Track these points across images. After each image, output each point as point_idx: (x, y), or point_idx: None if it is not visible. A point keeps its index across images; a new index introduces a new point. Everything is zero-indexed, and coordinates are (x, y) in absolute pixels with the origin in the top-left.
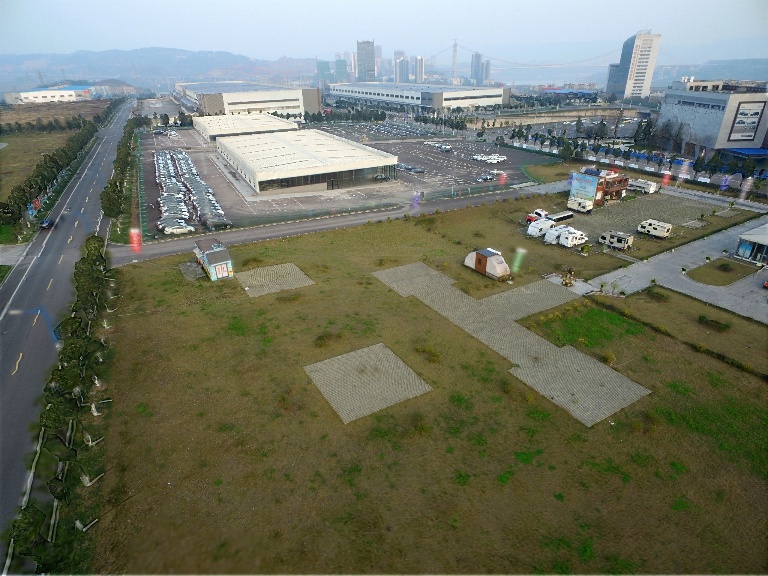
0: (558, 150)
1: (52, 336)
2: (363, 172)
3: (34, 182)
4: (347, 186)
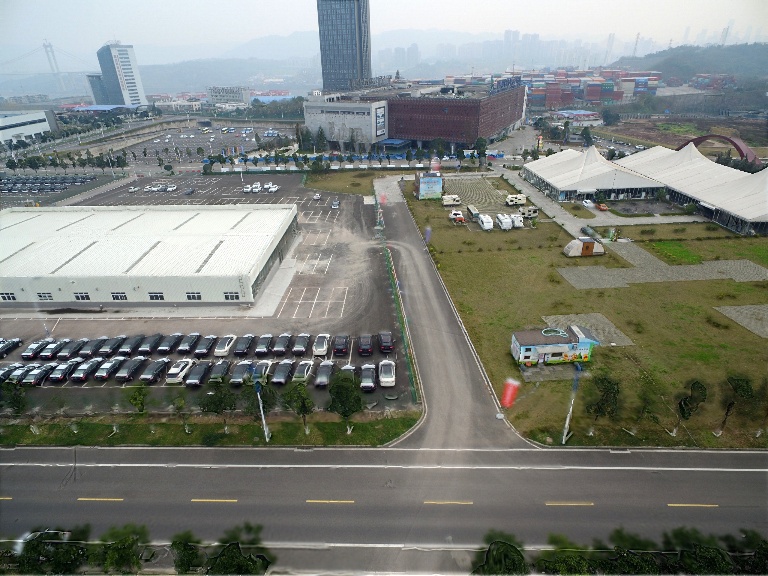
0: (308, 166)
1: (745, 482)
2: (288, 232)
3: None
4: (285, 253)
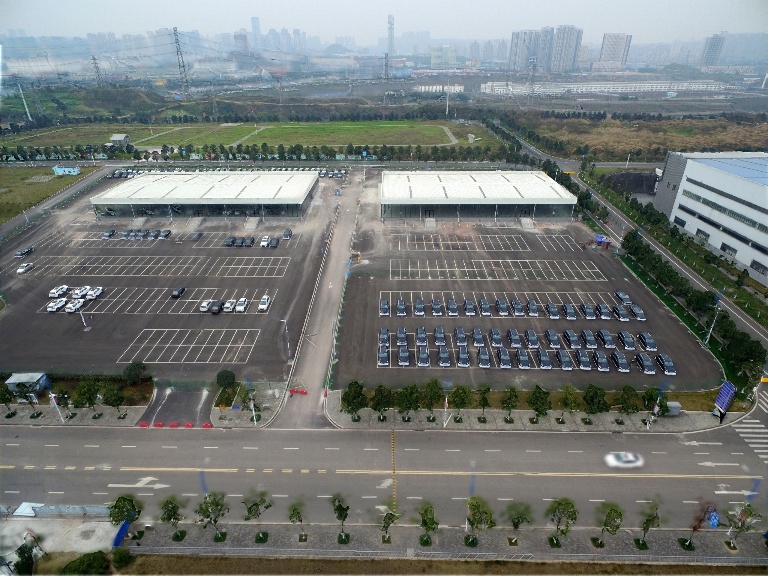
0: None
1: None
2: None
3: (204, 147)
4: None
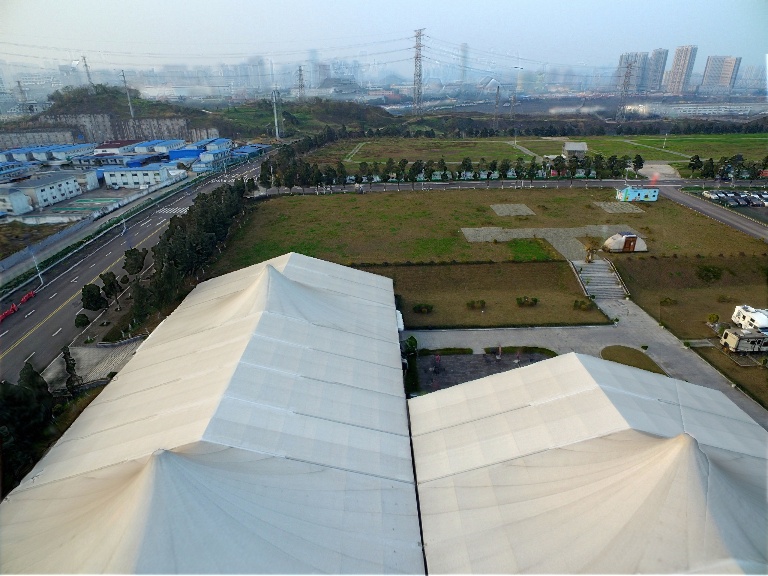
0: None
1: (568, 184)
2: None
3: (765, 158)
4: None
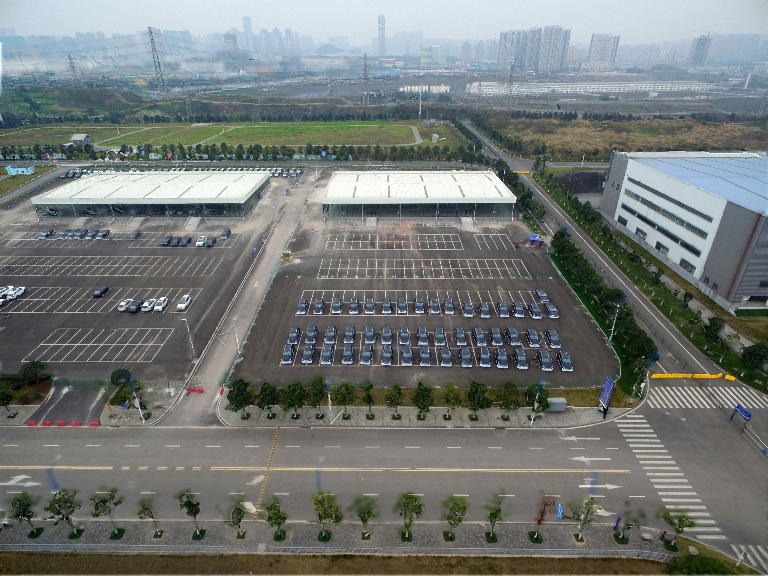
0: None
1: None
2: None
3: None
4: None
